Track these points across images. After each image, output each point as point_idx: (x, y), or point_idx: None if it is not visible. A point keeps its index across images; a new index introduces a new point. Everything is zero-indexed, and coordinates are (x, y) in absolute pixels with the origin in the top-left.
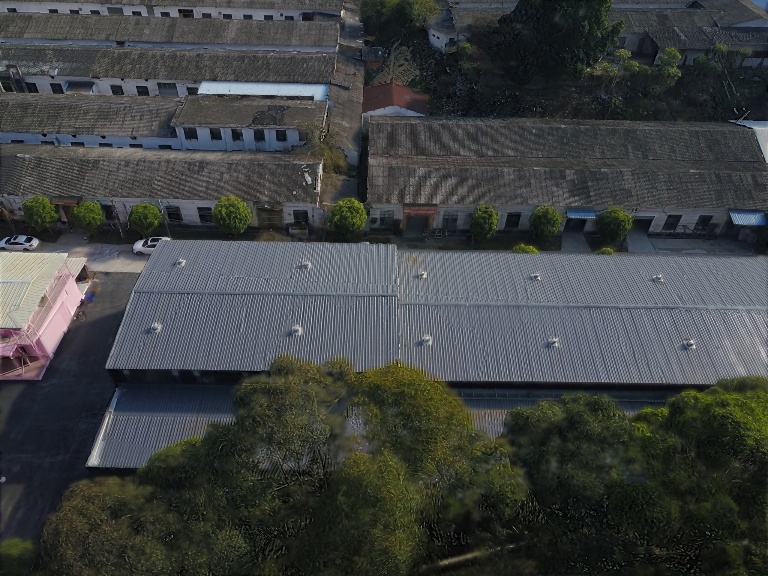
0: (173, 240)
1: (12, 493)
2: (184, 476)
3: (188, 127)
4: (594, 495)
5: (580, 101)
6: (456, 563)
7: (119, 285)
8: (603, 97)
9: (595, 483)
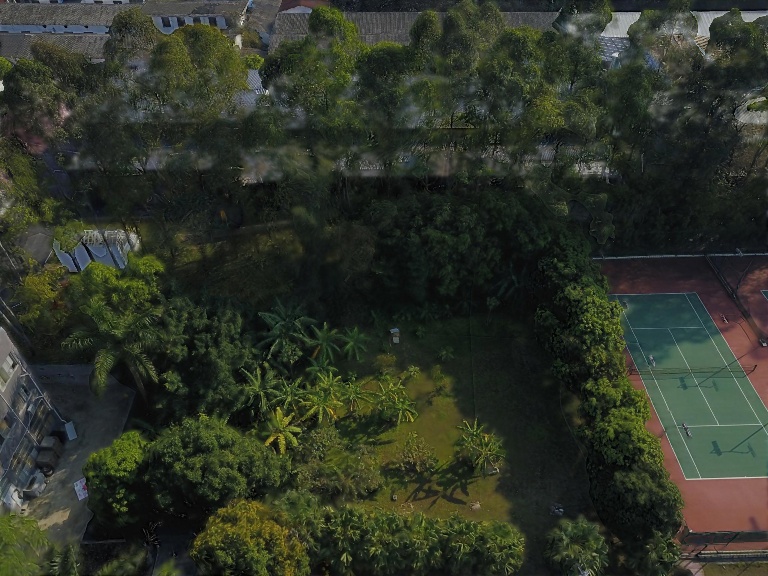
0: None
1: None
2: (97, 64)
3: None
4: (272, 56)
5: (445, 3)
6: (229, 118)
7: None
8: None
9: (275, 54)
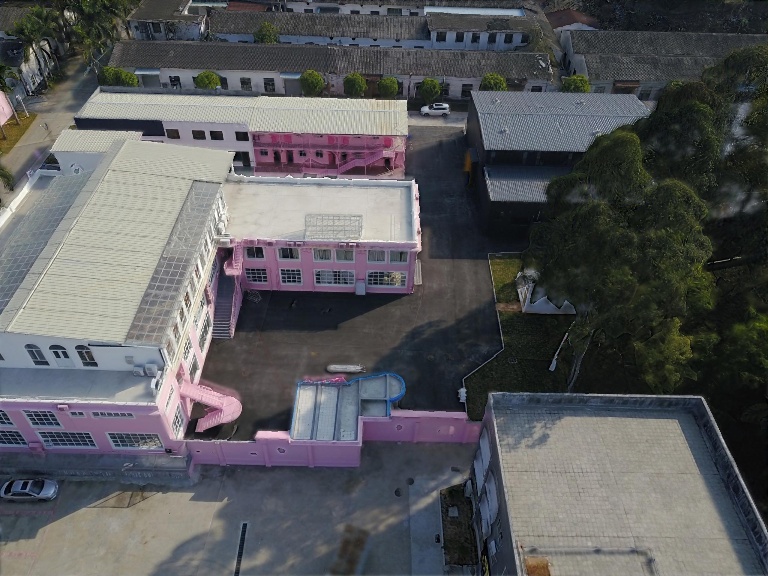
0: (480, 91)
1: (424, 231)
2: None
3: (441, 31)
4: None
5: (714, 23)
6: None
7: (423, 132)
8: (732, 20)
9: None
